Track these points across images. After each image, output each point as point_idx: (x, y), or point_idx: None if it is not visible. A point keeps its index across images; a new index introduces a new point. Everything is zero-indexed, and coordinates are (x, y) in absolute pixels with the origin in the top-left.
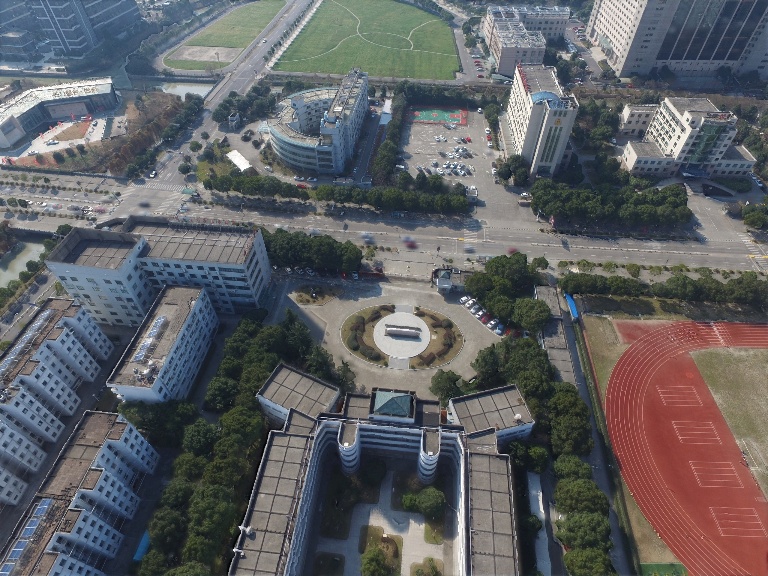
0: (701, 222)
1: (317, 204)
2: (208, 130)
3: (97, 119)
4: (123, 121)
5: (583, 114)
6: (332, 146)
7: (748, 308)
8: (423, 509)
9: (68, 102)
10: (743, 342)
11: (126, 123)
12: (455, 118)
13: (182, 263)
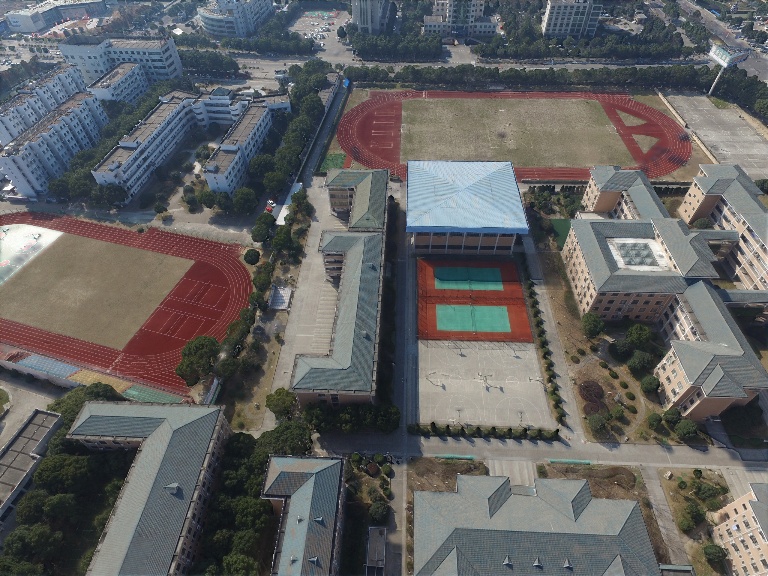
0: (453, 56)
1: (223, 52)
2: (165, 22)
3: (93, 18)
4: (110, 19)
5: (408, 6)
6: (233, 17)
7: (449, 86)
8: None
9: (74, 7)
10: (435, 97)
11: (112, 19)
12: (330, 14)
13: (129, 50)
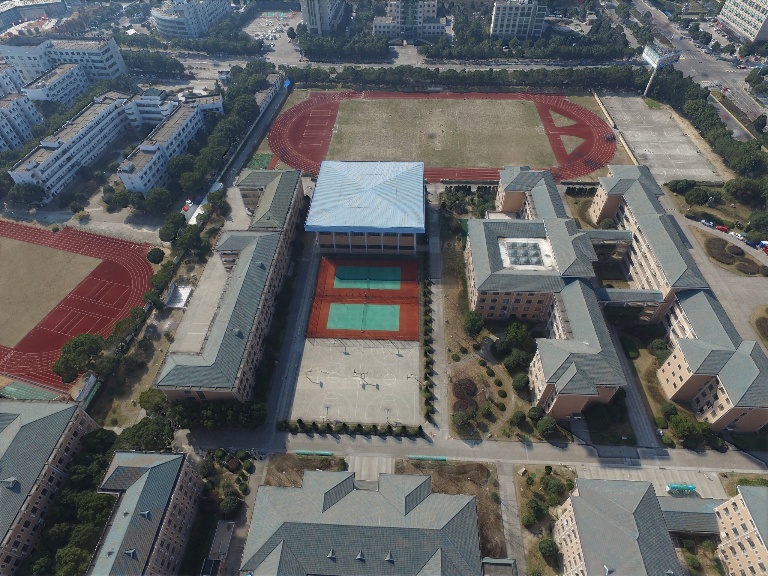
0: (399, 56)
1: (173, 52)
2: (122, 23)
3: (52, 19)
4: (68, 19)
5: (362, 7)
6: (184, 18)
7: (390, 86)
8: None
9: (33, 8)
10: (373, 97)
11: None
12: (287, 15)
13: (69, 51)
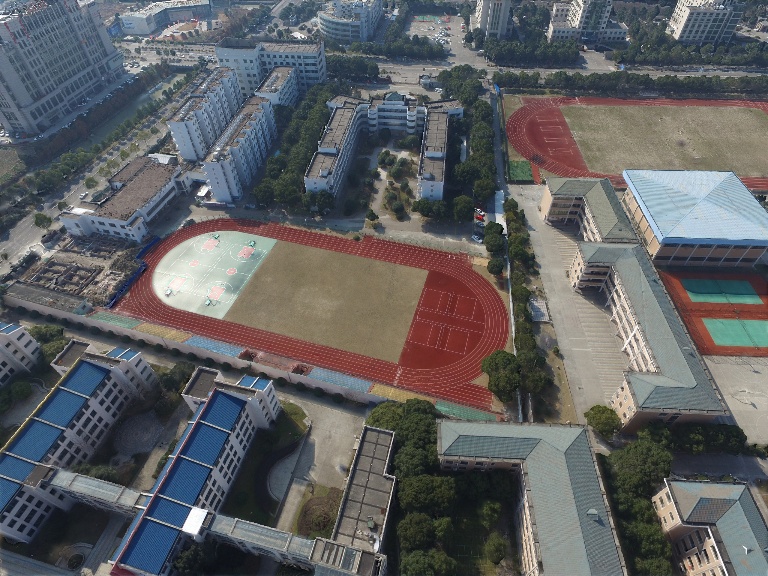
0: (588, 62)
1: (351, 56)
2: None
3: (201, 21)
4: (219, 22)
5: (526, 11)
6: (360, 21)
7: (600, 92)
8: (408, 142)
9: (182, 9)
10: (591, 103)
11: (221, 22)
12: (442, 19)
13: (283, 54)
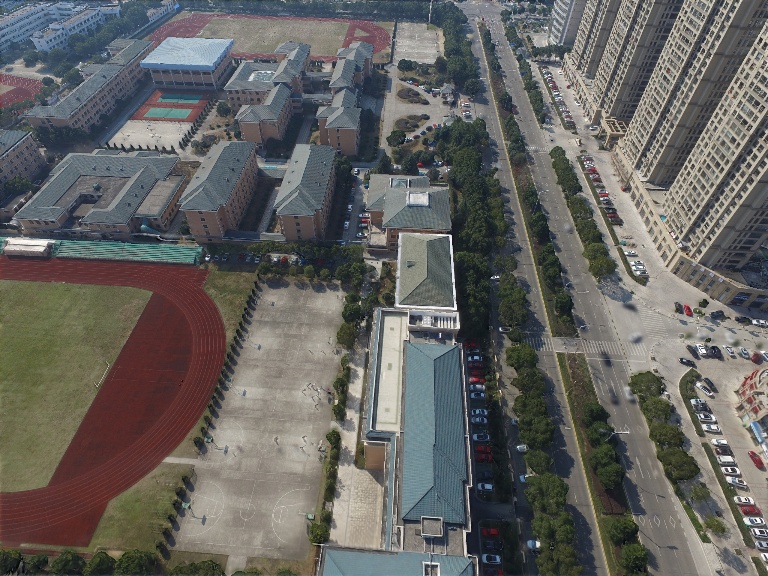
0: None
1: None
2: None
3: None
4: None
5: None
6: None
7: (253, 12)
8: None
9: None
10: (237, 17)
11: None
12: None
13: None
